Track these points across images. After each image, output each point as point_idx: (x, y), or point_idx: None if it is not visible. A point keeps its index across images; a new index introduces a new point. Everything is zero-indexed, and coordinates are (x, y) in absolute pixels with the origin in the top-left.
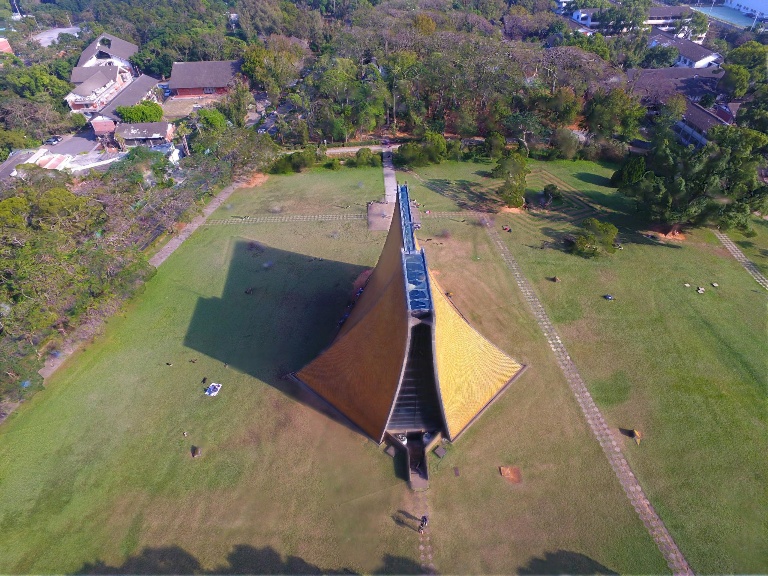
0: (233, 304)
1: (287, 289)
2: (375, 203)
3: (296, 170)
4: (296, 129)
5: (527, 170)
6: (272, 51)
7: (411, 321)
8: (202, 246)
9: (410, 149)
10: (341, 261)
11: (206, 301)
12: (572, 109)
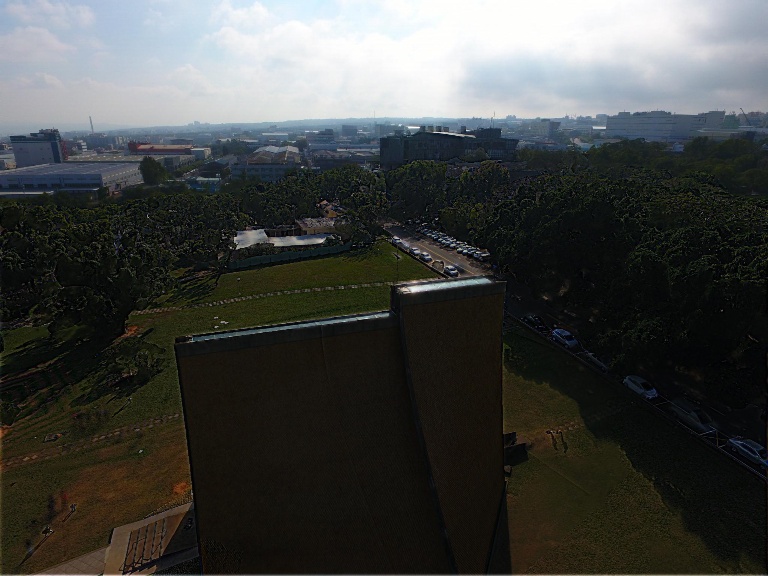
0: None
1: None
2: None
3: None
4: None
5: None
6: None
7: None
8: None
9: None
10: None
11: None
12: None
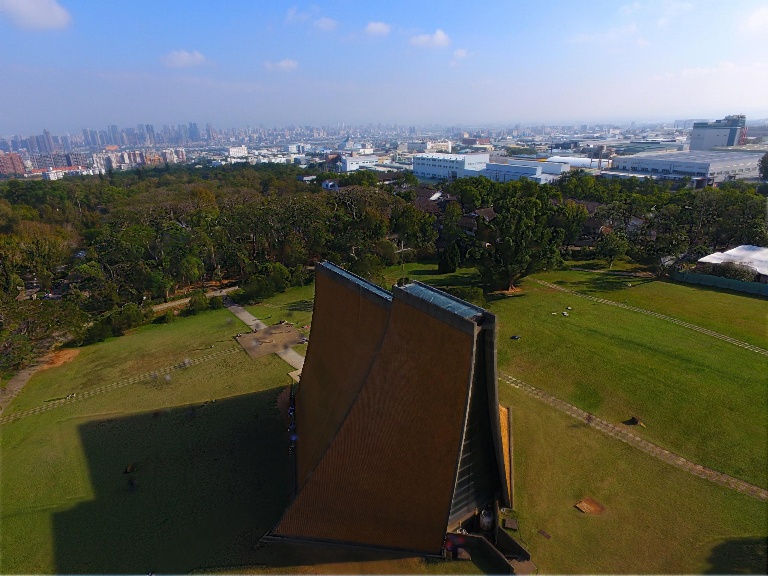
0: (112, 494)
1: (189, 445)
2: (243, 334)
3: (116, 335)
4: (101, 293)
5: (382, 267)
6: (27, 237)
7: (475, 328)
8: (10, 449)
9: (254, 280)
10: (243, 393)
11: (59, 510)
12: (382, 225)
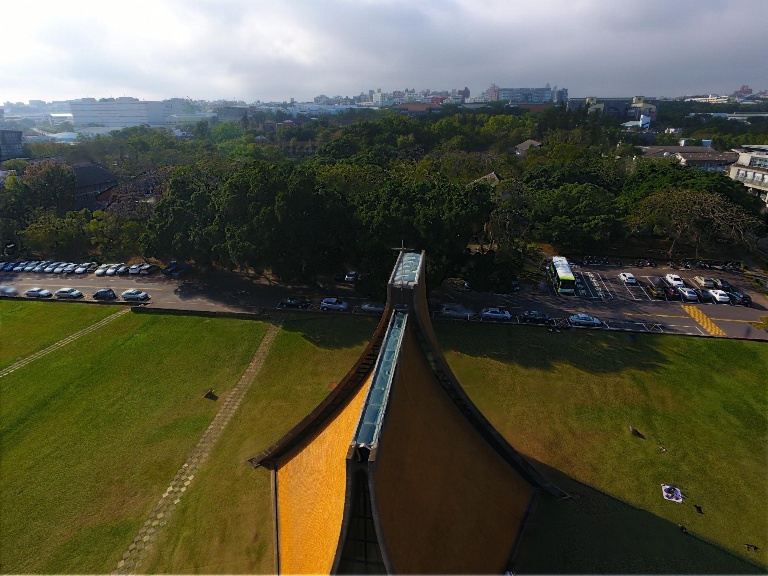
0: None
1: None
2: None
3: None
4: None
5: None
6: None
7: None
8: None
9: None
10: None
11: None
12: None
